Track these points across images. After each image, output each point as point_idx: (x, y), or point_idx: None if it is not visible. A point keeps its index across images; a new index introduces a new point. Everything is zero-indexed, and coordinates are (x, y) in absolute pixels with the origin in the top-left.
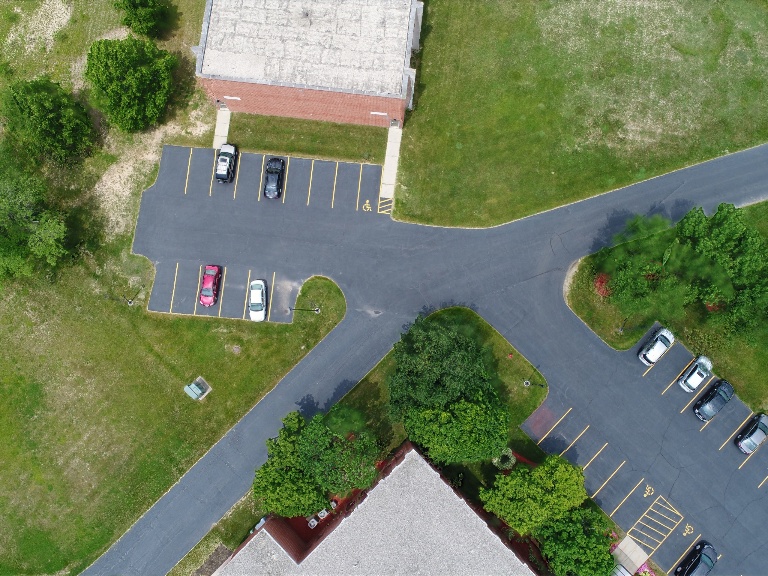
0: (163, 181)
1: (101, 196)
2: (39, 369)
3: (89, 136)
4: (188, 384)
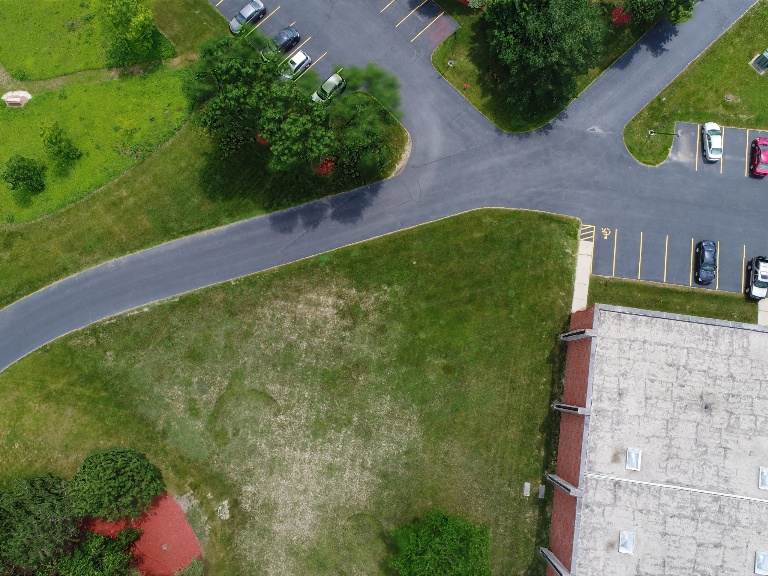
0: None
1: None
2: None
3: None
4: None
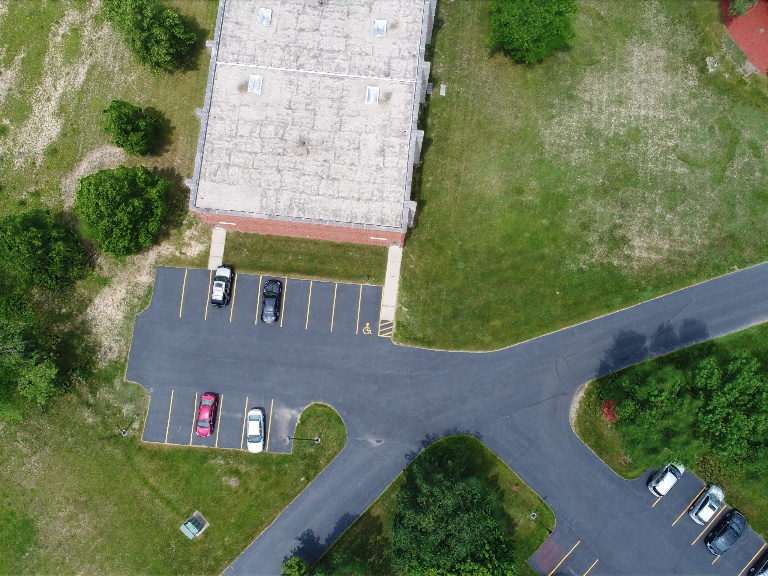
0: (157, 304)
1: (93, 320)
2: (30, 503)
3: (80, 260)
4: (184, 519)
